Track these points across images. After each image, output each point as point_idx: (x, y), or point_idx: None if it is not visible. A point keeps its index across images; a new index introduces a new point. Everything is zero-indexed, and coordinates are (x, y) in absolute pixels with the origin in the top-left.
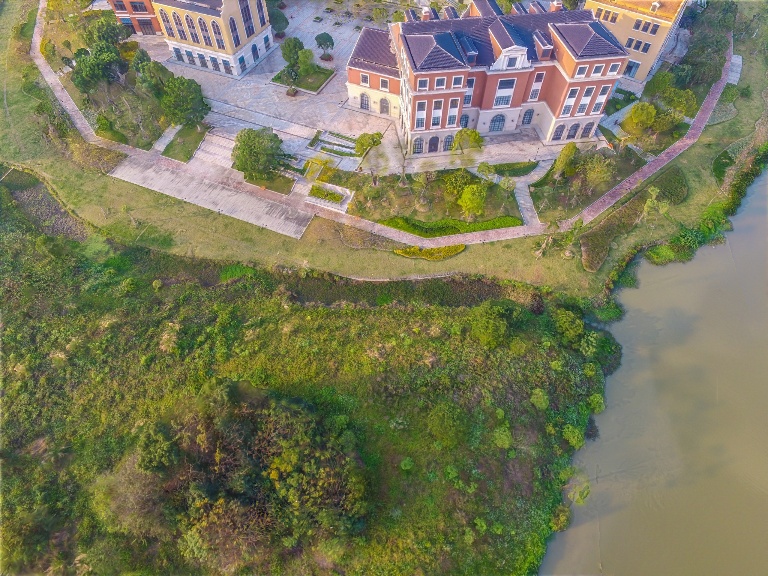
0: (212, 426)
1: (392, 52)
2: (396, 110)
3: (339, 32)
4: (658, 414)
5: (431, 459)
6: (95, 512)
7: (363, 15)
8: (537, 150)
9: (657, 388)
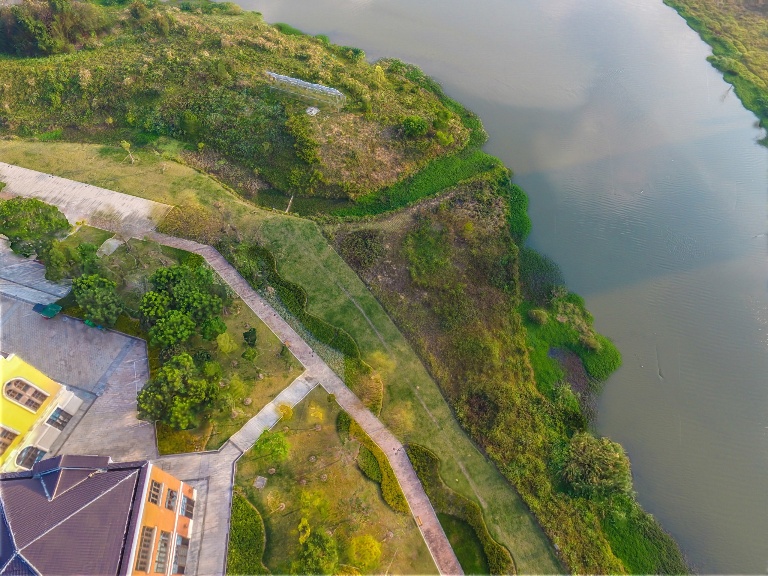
0: (26, 3)
1: None
2: None
3: None
4: None
5: None
6: None
7: None
8: None
9: None
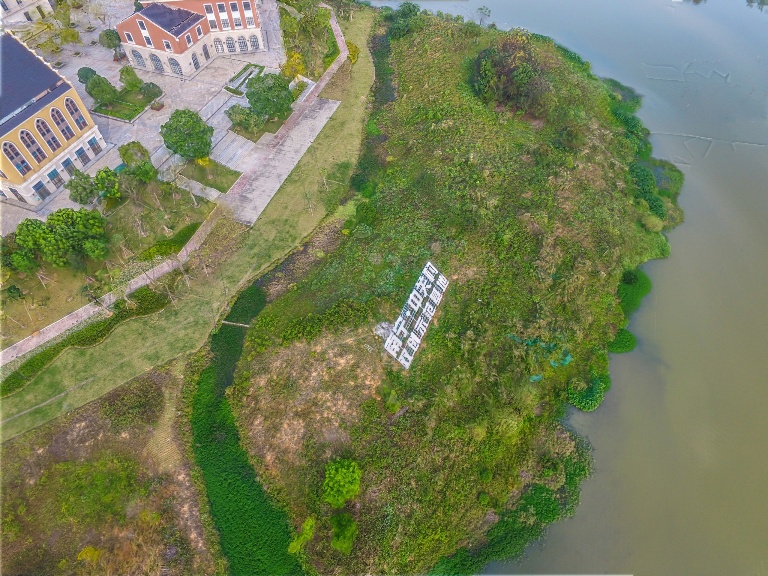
0: None
1: (176, 9)
2: (213, 47)
3: None
4: (440, 6)
5: (487, 38)
6: None
7: None
8: (267, 6)
9: (427, 4)
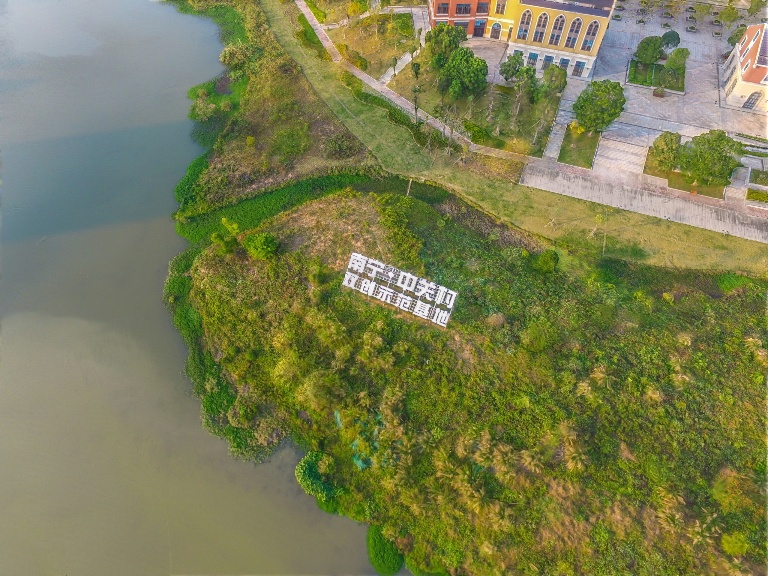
0: None
1: None
2: None
3: (650, 30)
4: None
5: None
6: None
7: (658, 12)
8: None
9: None
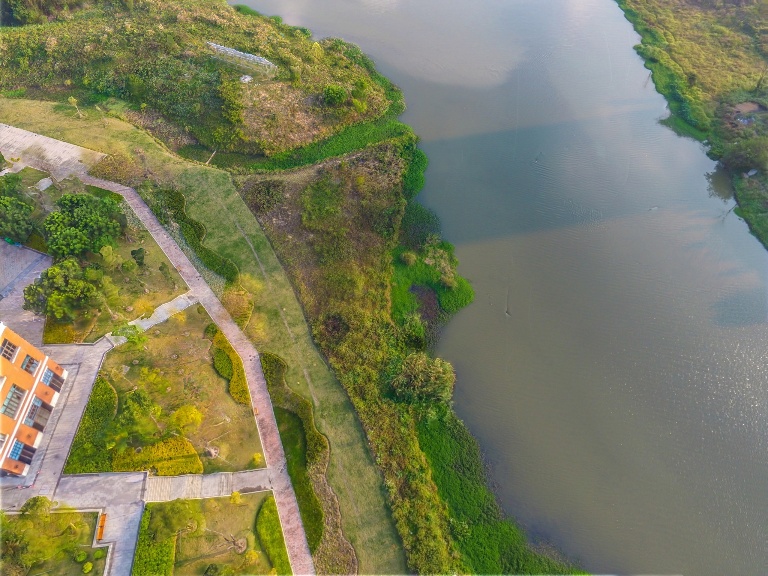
0: None
1: None
2: None
3: None
4: None
5: None
6: (96, 7)
7: None
8: None
9: None
